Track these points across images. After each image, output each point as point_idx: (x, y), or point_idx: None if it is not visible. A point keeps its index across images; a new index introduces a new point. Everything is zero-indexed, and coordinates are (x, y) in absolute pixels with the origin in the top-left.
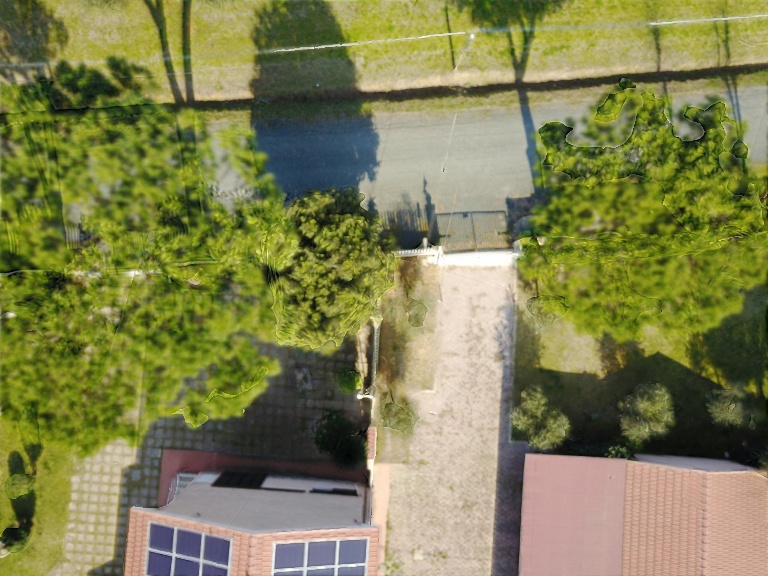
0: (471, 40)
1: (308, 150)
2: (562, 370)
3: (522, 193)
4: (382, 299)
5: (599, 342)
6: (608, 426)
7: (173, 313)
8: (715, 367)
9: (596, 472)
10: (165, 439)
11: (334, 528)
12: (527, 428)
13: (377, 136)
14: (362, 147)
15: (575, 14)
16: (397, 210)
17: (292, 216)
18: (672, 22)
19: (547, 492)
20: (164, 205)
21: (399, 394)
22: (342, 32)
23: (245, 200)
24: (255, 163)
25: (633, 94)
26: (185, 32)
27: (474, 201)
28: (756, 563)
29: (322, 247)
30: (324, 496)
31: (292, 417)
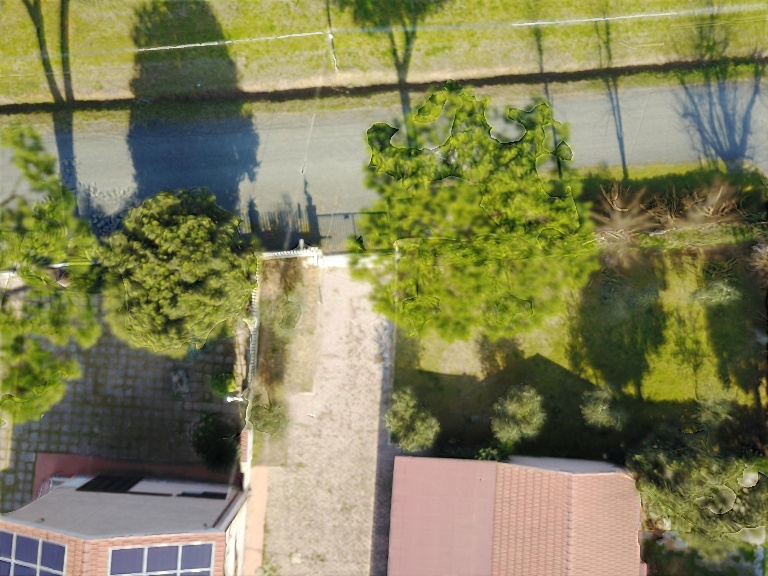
0: (353, 40)
1: (188, 150)
2: (442, 372)
3: (403, 194)
4: (260, 301)
5: (479, 344)
6: (487, 428)
7: (49, 315)
8: (594, 368)
9: (466, 474)
10: (39, 443)
11: (176, 533)
12: (399, 430)
13: (257, 136)
14: (242, 148)
15: (457, 15)
16: (278, 211)
17: (136, 217)
18: (534, 23)
19: (417, 495)
20: (40, 206)
21: (277, 396)
22: (223, 32)
23: (123, 201)
24: (133, 163)
25: (514, 95)
26: (63, 31)
27: (355, 202)
28: (625, 565)
29: (163, 249)
30: (190, 500)
31: (169, 420)
